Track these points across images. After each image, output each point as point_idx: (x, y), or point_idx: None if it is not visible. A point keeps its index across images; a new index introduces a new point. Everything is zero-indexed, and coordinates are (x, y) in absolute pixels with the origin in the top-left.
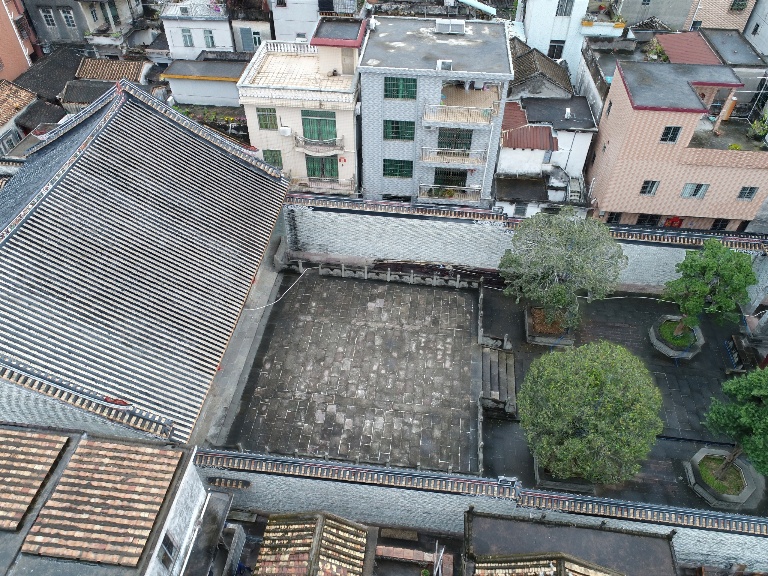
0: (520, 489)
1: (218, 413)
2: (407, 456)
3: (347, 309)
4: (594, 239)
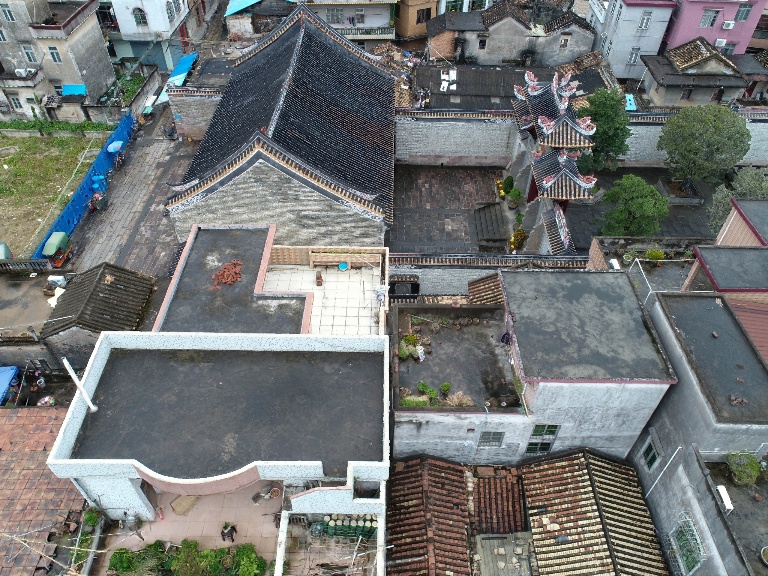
0: None
1: None
2: None
3: None
4: (759, 183)
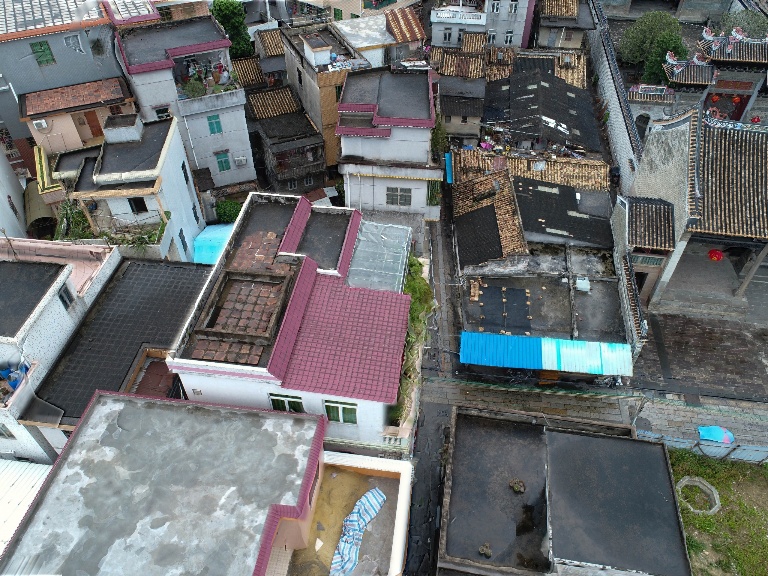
0: (605, 25)
1: (617, 15)
2: (618, 47)
3: (691, 36)
4: None
